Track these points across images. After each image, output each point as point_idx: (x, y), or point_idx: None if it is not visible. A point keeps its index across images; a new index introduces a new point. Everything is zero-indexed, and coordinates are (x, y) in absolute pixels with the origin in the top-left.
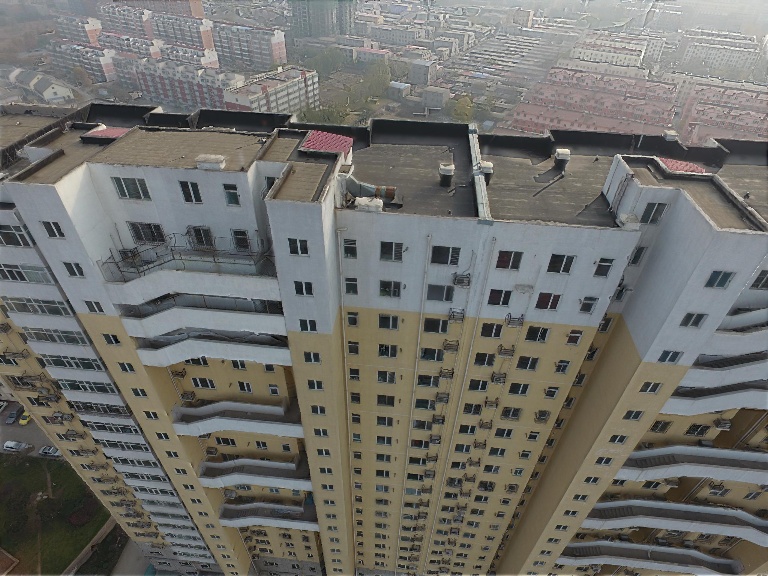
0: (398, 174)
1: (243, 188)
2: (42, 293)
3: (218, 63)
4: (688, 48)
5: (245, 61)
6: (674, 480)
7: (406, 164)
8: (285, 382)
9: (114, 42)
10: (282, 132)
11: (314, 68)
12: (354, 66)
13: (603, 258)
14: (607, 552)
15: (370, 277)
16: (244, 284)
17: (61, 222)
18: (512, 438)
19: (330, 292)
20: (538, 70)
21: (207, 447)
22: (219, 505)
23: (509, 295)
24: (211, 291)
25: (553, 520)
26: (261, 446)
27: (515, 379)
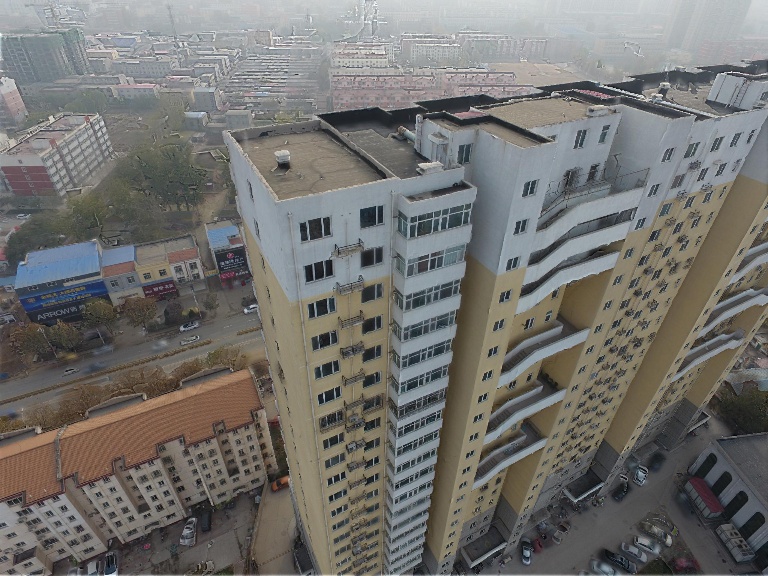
0: None
1: (614, 126)
2: (450, 275)
3: None
4: (412, 49)
5: None
6: None
7: None
8: (560, 304)
9: None
10: None
11: None
12: (120, 105)
13: (753, 130)
14: None
15: None
16: (625, 199)
17: (542, 178)
18: (667, 290)
19: None
20: (309, 82)
21: None
22: None
23: (706, 171)
24: (602, 213)
25: (686, 341)
26: (511, 387)
27: None
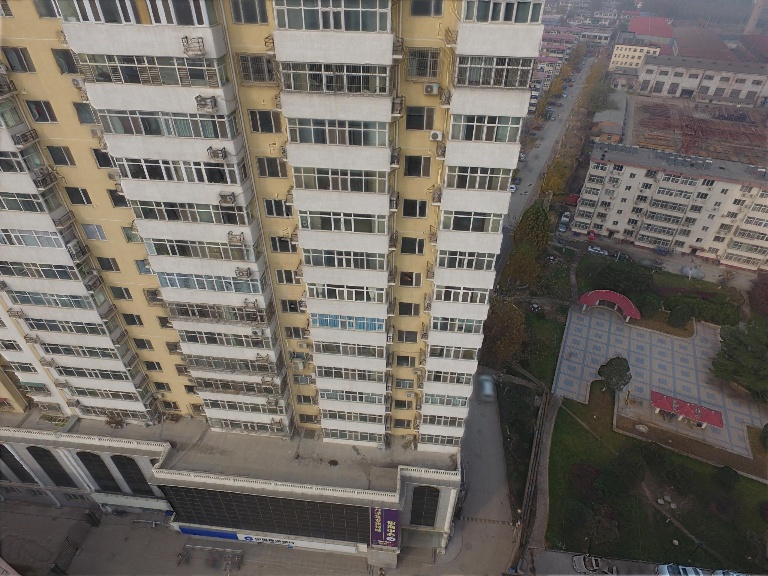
0: None
1: None
2: None
3: None
4: None
5: None
6: None
7: None
8: None
9: None
10: None
11: None
12: None
13: None
14: None
15: None
16: None
17: None
18: None
19: None
20: None
21: None
22: None
23: None
24: None
25: None
26: None
27: None
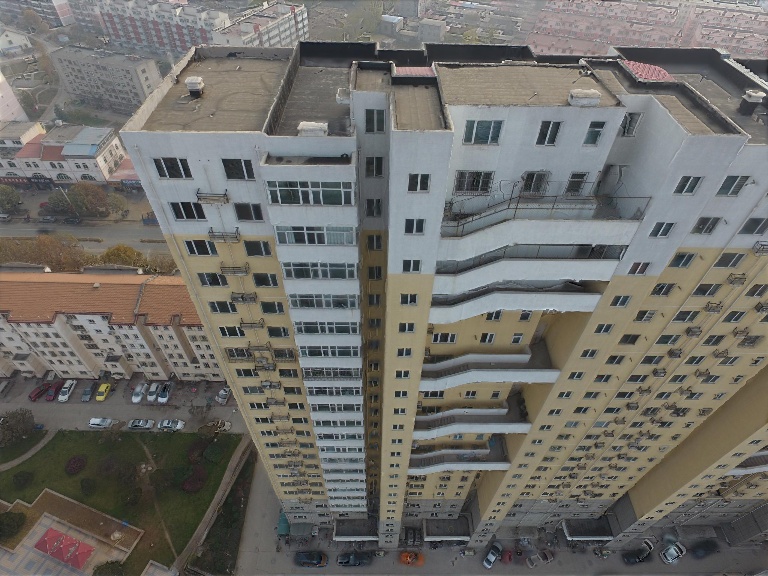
0: None
1: (613, 125)
2: (337, 256)
3: None
4: None
5: None
6: None
7: None
8: (534, 330)
9: None
10: (588, 63)
11: (295, 2)
12: None
13: None
14: None
15: None
16: (600, 229)
17: (435, 173)
18: (735, 365)
19: None
20: None
21: None
22: None
23: None
24: (558, 239)
25: (752, 436)
26: (469, 395)
27: None
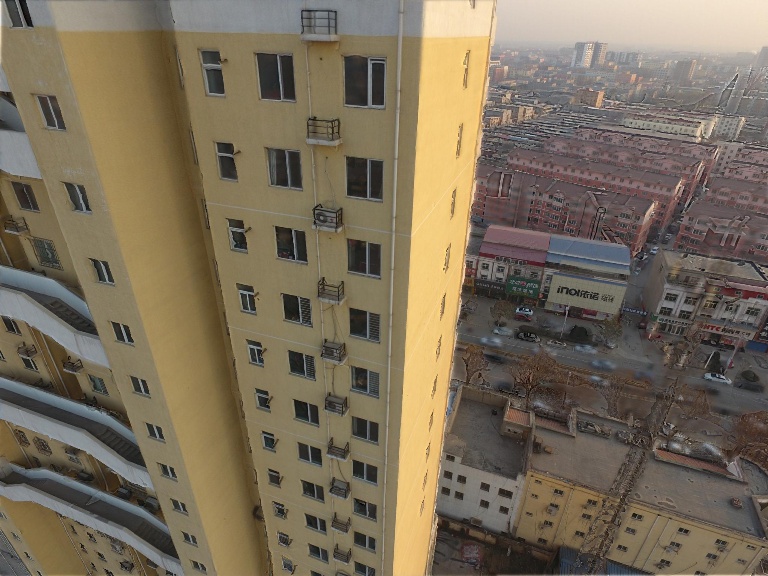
0: None
1: None
2: None
3: None
4: None
5: None
6: None
7: None
8: None
9: None
10: None
11: None
12: None
13: None
14: None
15: None
16: None
17: None
18: None
19: None
20: None
21: None
22: None
23: None
24: None
25: None
26: None
27: None
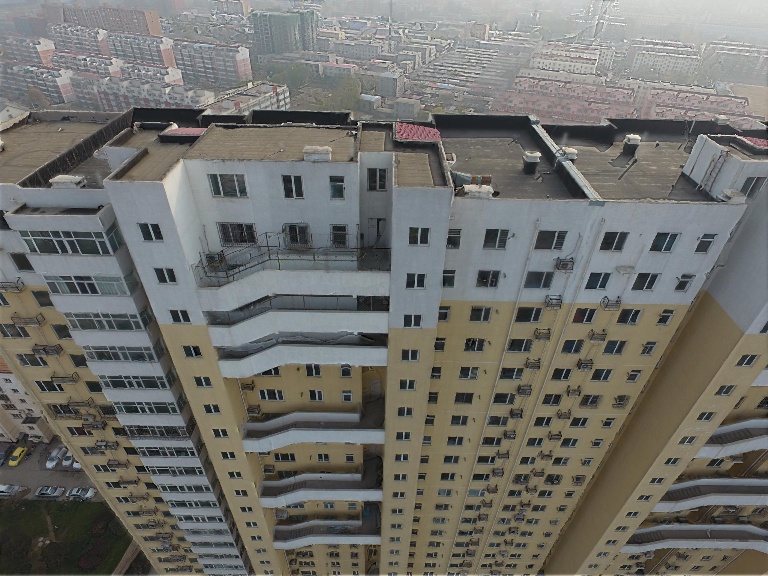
0: (478, 165)
1: (351, 179)
2: (114, 306)
3: (182, 81)
4: (637, 56)
5: (209, 78)
6: (739, 456)
7: (480, 155)
8: (361, 387)
9: (69, 62)
10: (365, 125)
11: (282, 83)
12: (321, 81)
13: (706, 234)
14: (669, 536)
15: (469, 268)
16: (353, 280)
17: (162, 223)
18: (587, 427)
19: (442, 283)
20: (500, 80)
21: (264, 465)
22: (272, 527)
23: (607, 278)
24: (315, 290)
25: (626, 507)
26: (323, 459)
27: (600, 365)
